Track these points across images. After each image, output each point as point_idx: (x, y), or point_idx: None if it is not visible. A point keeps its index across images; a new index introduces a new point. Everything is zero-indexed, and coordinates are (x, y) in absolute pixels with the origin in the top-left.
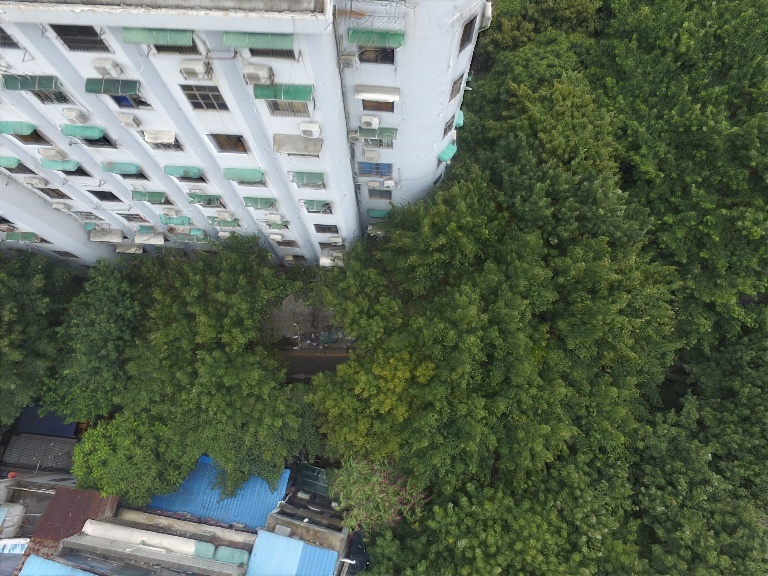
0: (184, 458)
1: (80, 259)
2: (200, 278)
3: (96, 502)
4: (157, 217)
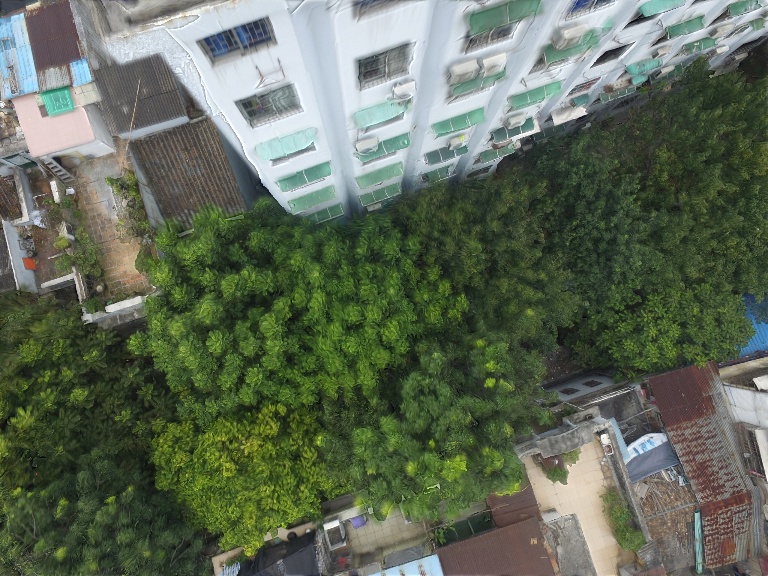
0: (761, 299)
1: (483, 174)
2: (720, 112)
3: (698, 374)
4: (606, 76)
